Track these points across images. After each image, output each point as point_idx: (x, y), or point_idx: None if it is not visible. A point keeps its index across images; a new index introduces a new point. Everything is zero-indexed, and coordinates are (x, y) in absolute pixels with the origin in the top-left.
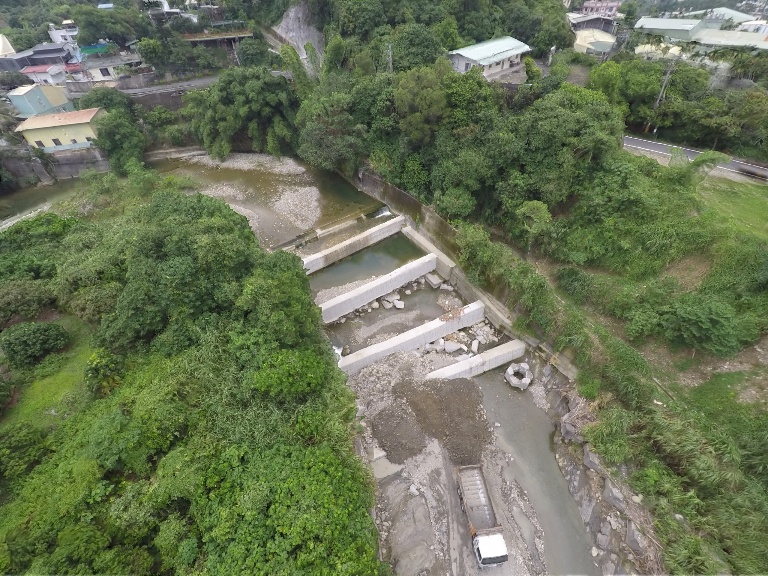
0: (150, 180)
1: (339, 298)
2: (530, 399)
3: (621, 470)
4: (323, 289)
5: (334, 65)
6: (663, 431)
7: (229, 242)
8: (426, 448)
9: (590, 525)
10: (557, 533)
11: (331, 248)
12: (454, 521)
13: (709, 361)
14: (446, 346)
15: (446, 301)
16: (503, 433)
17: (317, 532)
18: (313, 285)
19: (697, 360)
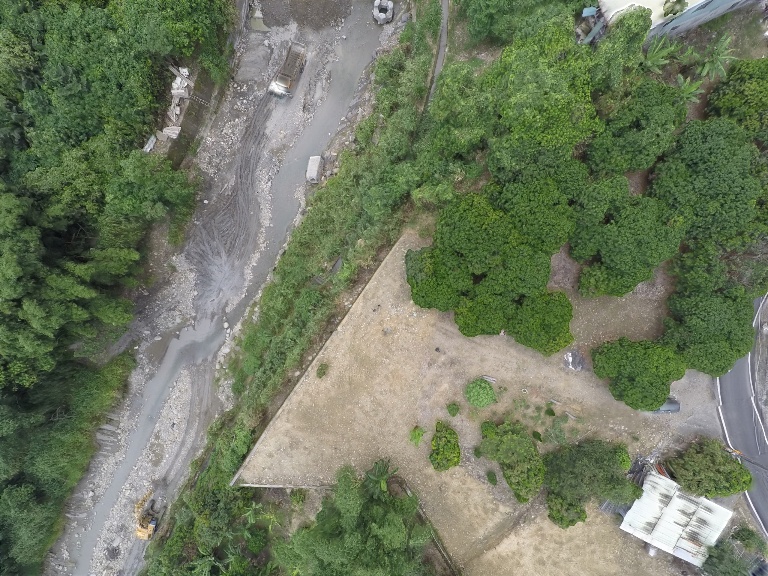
0: None
1: None
2: (379, 32)
3: (379, 87)
4: None
5: None
6: (406, 71)
7: None
8: (288, 26)
9: (350, 108)
10: (332, 103)
11: None
12: None
13: (480, 47)
14: None
15: None
16: (344, 44)
17: (172, 5)
18: None
19: (475, 43)
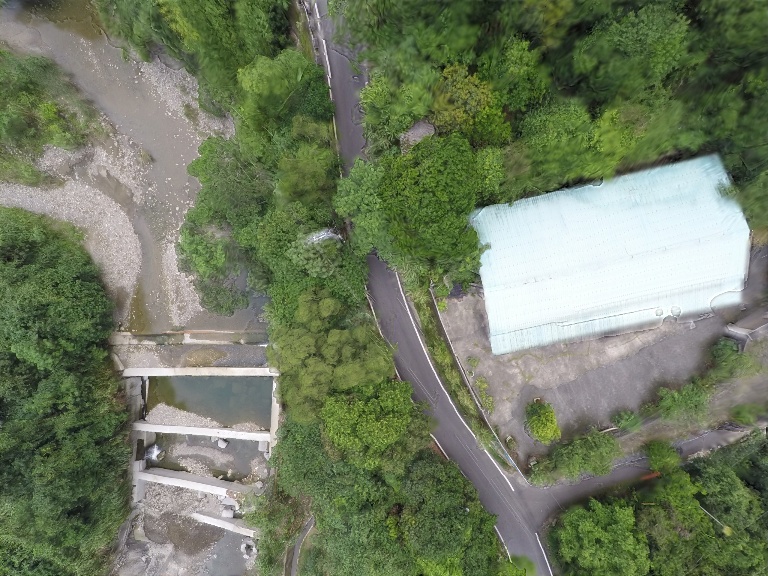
0: (18, 119)
1: (165, 428)
2: None
3: None
4: (164, 403)
5: (263, 111)
6: None
7: None
8: (165, 544)
9: None
10: None
11: (186, 370)
12: (157, 575)
13: None
14: (224, 501)
15: (257, 467)
16: (215, 560)
17: None
18: (161, 389)
19: None
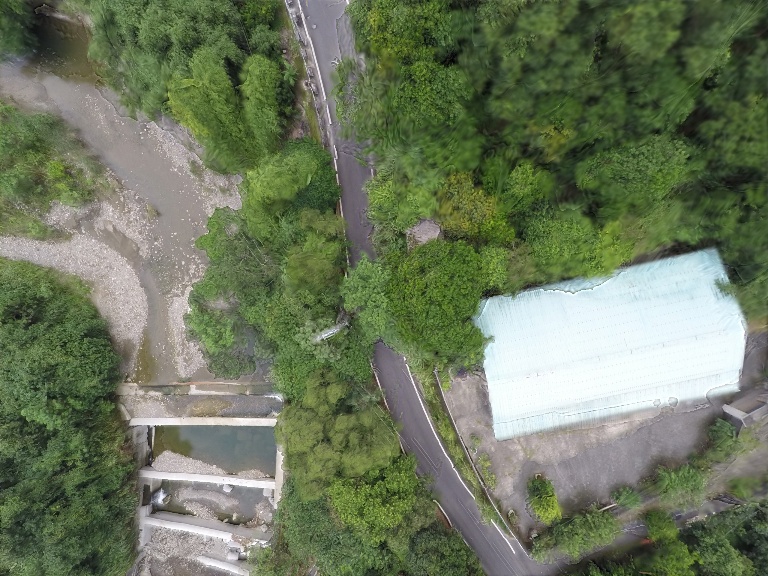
0: (26, 179)
1: (171, 476)
2: None
3: None
4: (170, 450)
5: None
6: None
7: (1, 560)
8: None
9: None
10: None
11: (192, 420)
12: None
13: None
14: (229, 544)
15: (262, 511)
16: None
17: None
18: (167, 436)
19: None
